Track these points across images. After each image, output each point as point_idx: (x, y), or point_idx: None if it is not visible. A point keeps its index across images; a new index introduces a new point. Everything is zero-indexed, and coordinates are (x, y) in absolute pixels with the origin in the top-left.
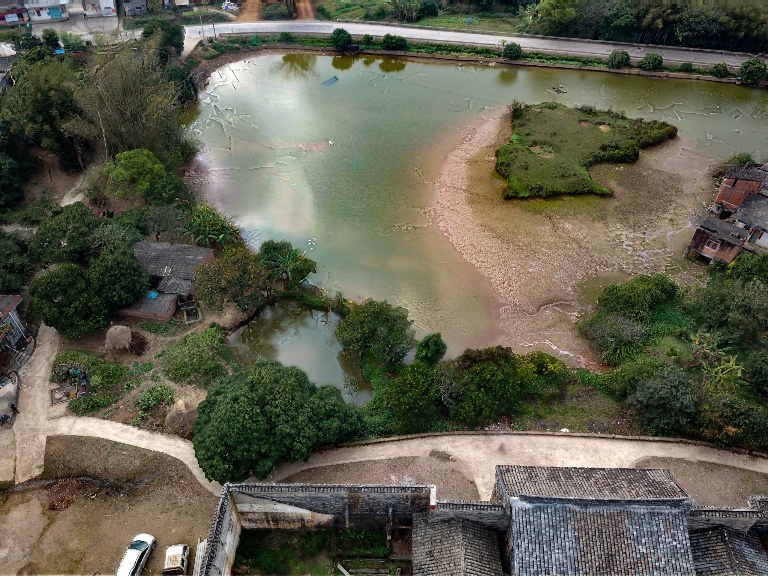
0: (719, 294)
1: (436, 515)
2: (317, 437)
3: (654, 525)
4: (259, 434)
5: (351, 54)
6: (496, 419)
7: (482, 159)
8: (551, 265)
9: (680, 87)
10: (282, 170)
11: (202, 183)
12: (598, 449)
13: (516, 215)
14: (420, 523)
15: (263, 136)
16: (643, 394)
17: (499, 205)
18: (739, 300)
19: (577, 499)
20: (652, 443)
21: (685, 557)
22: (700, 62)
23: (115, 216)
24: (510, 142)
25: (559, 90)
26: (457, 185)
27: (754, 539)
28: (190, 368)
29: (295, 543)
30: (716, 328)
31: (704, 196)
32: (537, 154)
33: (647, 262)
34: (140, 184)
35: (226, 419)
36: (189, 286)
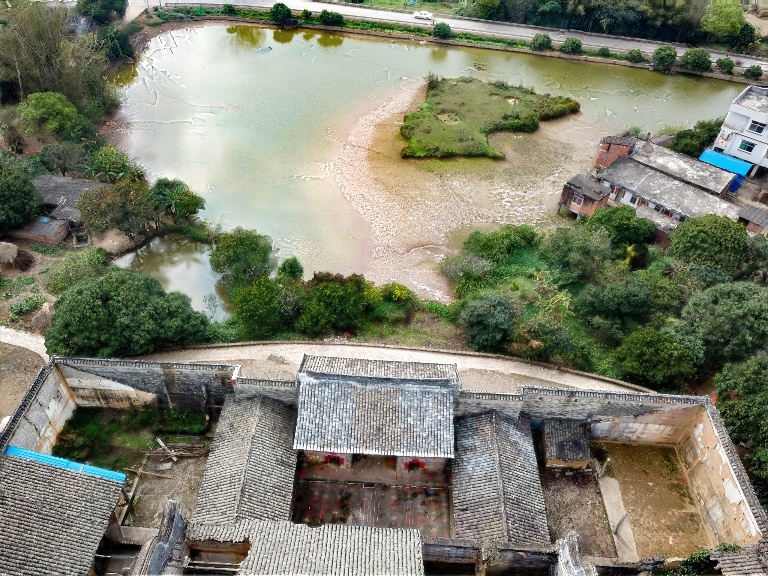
0: (563, 237)
1: (240, 391)
2: (158, 333)
3: (424, 402)
4: (99, 324)
5: (290, 27)
6: (339, 334)
7: (391, 123)
8: (431, 215)
9: (597, 70)
10: (198, 124)
11: (120, 132)
12: (422, 360)
13: (410, 172)
14: (230, 402)
15: (188, 95)
16: (467, 313)
17: (396, 163)
18: (580, 242)
19: (357, 376)
20: (473, 358)
21: (446, 428)
22: (616, 48)
23: (29, 155)
24: (421, 110)
25: (480, 67)
26: (361, 144)
27: (524, 425)
28: (68, 283)
29: (122, 420)
30: (560, 269)
31: (590, 163)
32: (443, 121)
33: (521, 216)
34: (49, 123)
35: (69, 309)
36: (81, 214)
